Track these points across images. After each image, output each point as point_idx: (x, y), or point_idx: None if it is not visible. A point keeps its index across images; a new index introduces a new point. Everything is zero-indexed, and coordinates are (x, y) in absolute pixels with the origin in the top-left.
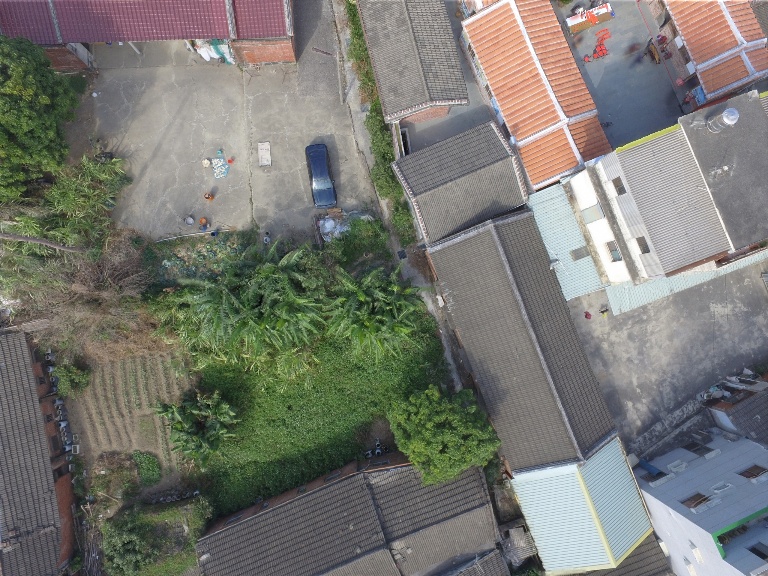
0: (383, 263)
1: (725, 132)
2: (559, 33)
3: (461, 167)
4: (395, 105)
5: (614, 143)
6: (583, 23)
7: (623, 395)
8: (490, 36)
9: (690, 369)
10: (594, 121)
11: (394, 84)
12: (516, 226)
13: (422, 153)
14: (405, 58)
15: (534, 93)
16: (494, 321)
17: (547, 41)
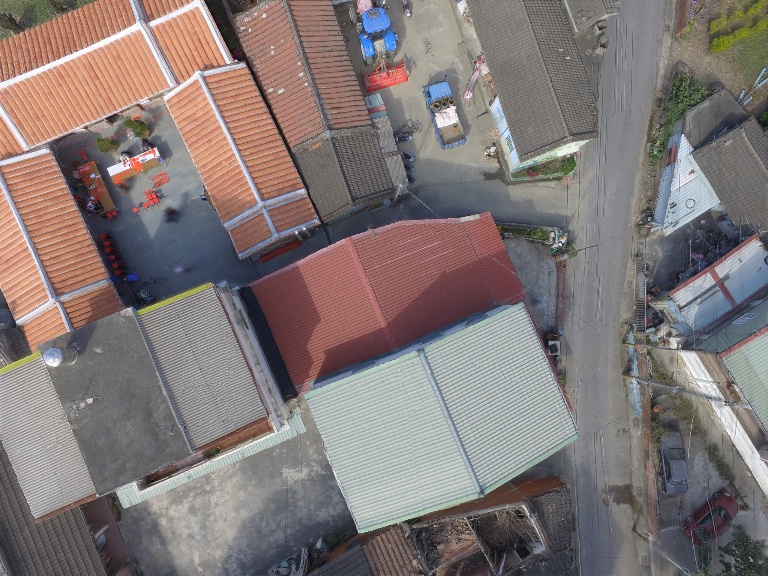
0: None
1: (91, 359)
2: (63, 197)
3: None
4: None
5: None
6: (126, 172)
7: (183, 575)
8: None
9: (259, 542)
10: (106, 291)
11: None
12: None
13: None
14: None
15: (27, 268)
16: None
17: (44, 208)
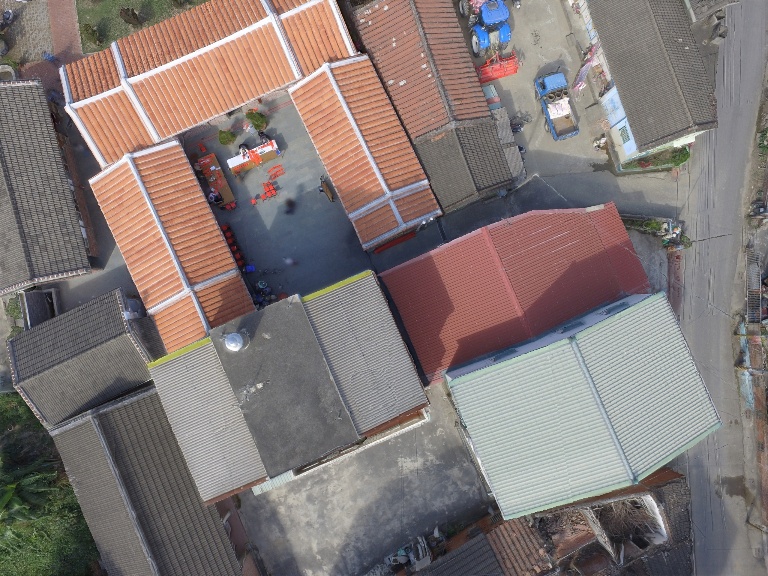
0: (32, 434)
1: (260, 345)
2: (193, 188)
3: (74, 346)
4: (3, 281)
5: (289, 289)
6: (245, 164)
7: (302, 563)
8: (115, 196)
9: (376, 531)
10: (235, 281)
11: (1, 258)
12: (138, 406)
13: (40, 329)
14: (9, 231)
15: (160, 258)
16: (111, 513)
17: (175, 199)
